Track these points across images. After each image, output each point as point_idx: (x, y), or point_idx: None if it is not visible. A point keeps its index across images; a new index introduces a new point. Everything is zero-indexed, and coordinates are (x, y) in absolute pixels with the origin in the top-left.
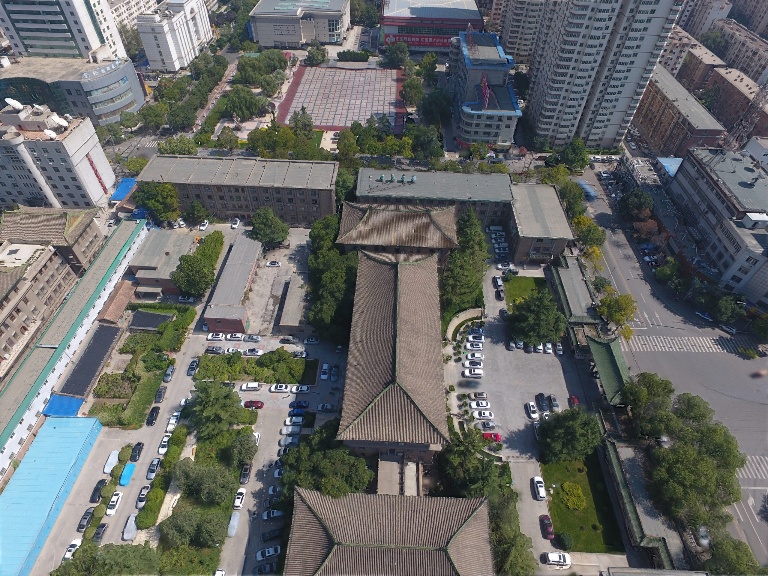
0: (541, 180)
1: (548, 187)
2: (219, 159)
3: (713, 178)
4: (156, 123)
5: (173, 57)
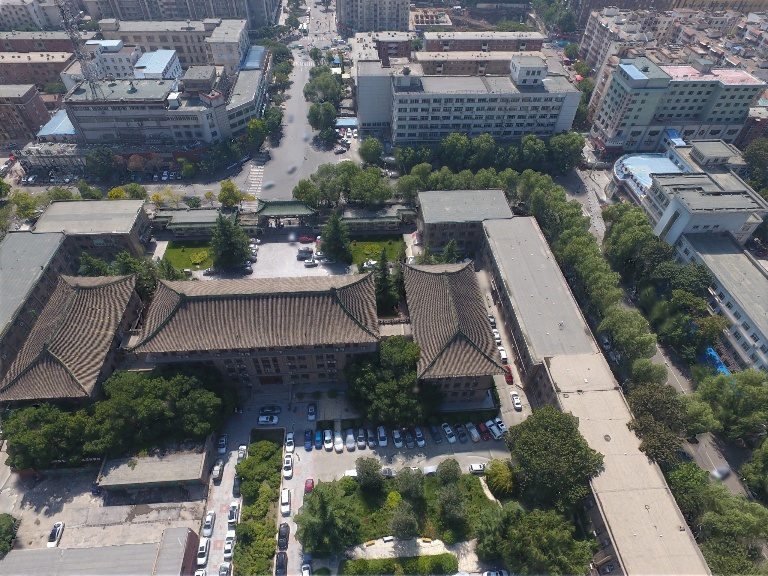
0: (24, 217)
1: (53, 206)
2: None
3: (117, 101)
4: None
5: None
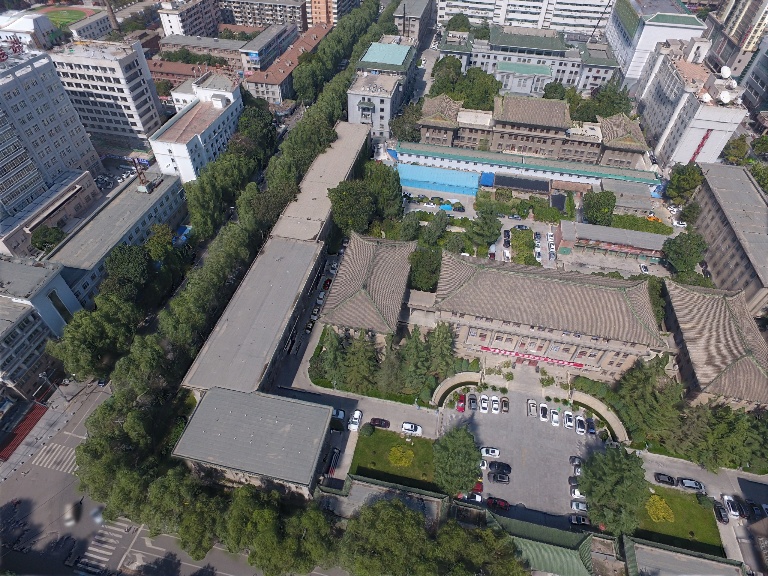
0: None
1: None
2: (767, 205)
3: None
4: None
5: None
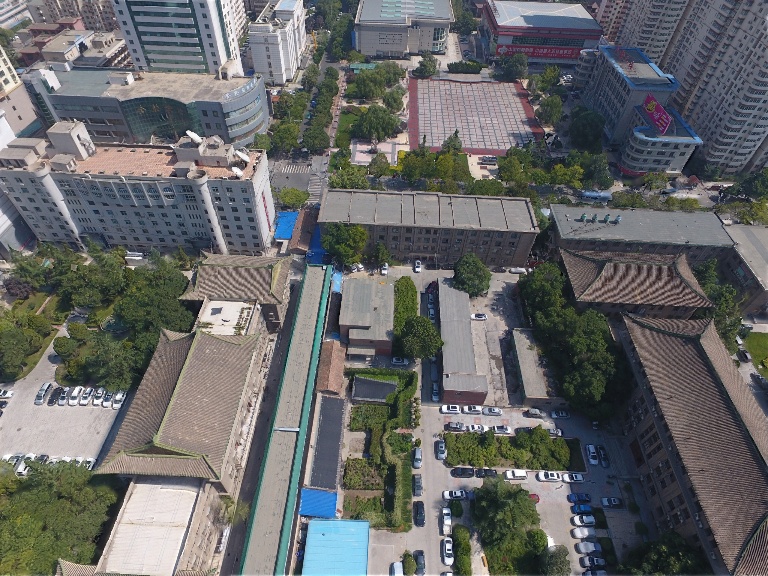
0: (740, 217)
1: (764, 228)
2: (397, 194)
3: None
4: (292, 146)
5: (282, 69)
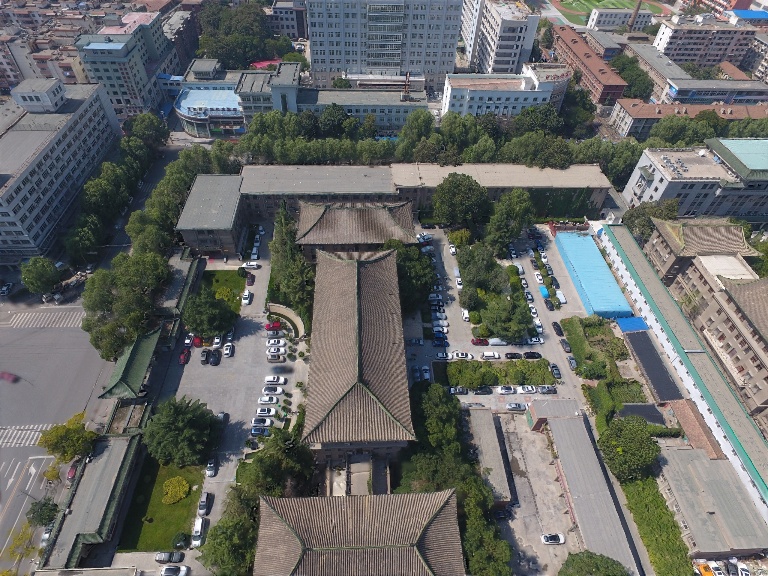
0: None
1: None
2: None
3: None
4: None
5: None
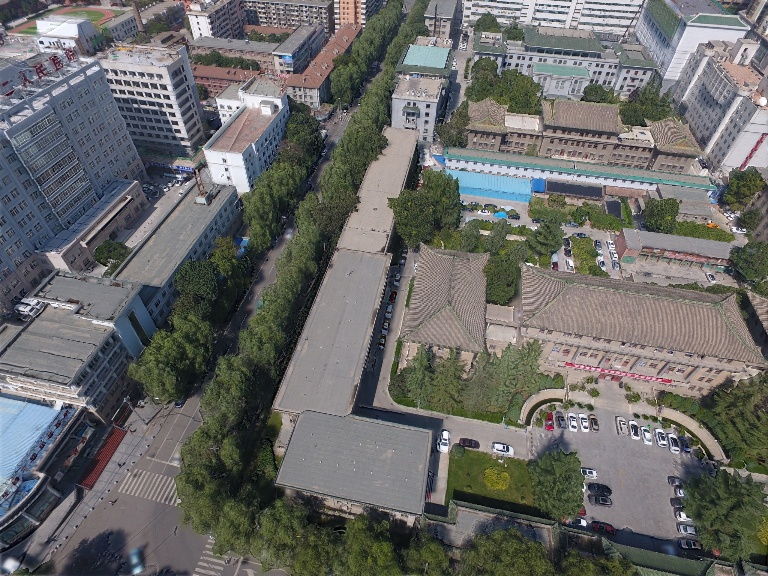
0: None
1: None
2: None
3: None
4: None
5: None
